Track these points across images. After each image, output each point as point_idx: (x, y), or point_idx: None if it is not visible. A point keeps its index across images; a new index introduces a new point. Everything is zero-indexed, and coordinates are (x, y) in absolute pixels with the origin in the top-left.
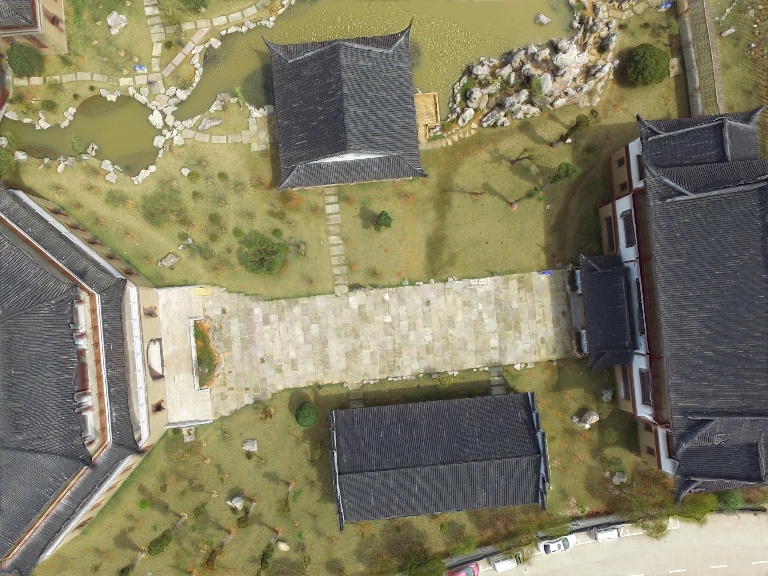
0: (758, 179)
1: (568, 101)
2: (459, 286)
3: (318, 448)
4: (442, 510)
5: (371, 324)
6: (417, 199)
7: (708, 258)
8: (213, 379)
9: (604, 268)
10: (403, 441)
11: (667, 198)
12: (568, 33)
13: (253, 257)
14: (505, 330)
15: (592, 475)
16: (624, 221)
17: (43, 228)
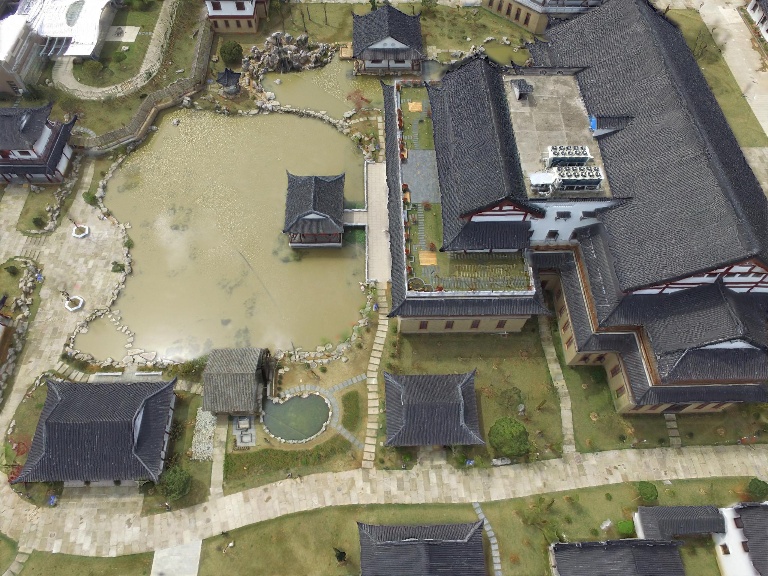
0: None
1: None
2: (340, 1)
3: None
4: None
5: None
6: None
7: None
8: None
9: None
10: None
11: None
12: (266, 77)
13: None
14: None
15: None
16: None
17: None
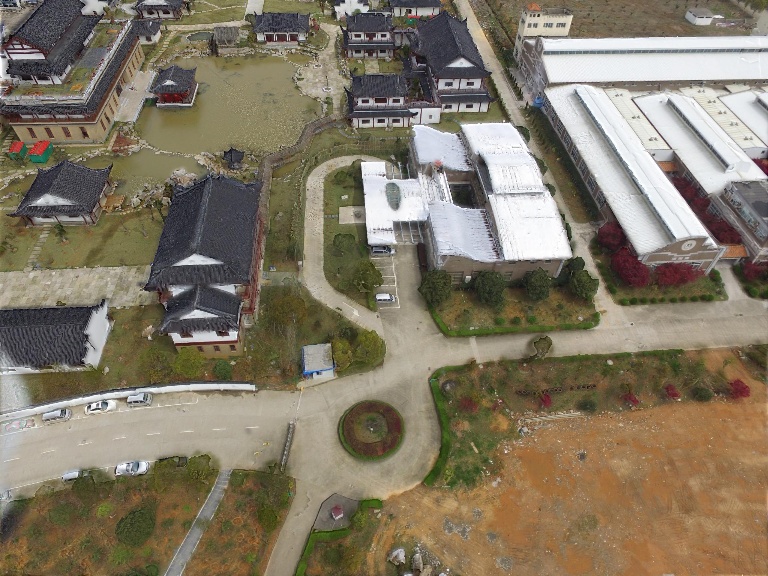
0: None
1: None
2: (100, 270)
3: None
4: (15, 366)
5: (36, 285)
6: (95, 234)
7: None
8: None
9: None
10: (7, 320)
11: None
12: None
13: None
14: (119, 290)
15: (143, 366)
16: None
17: None
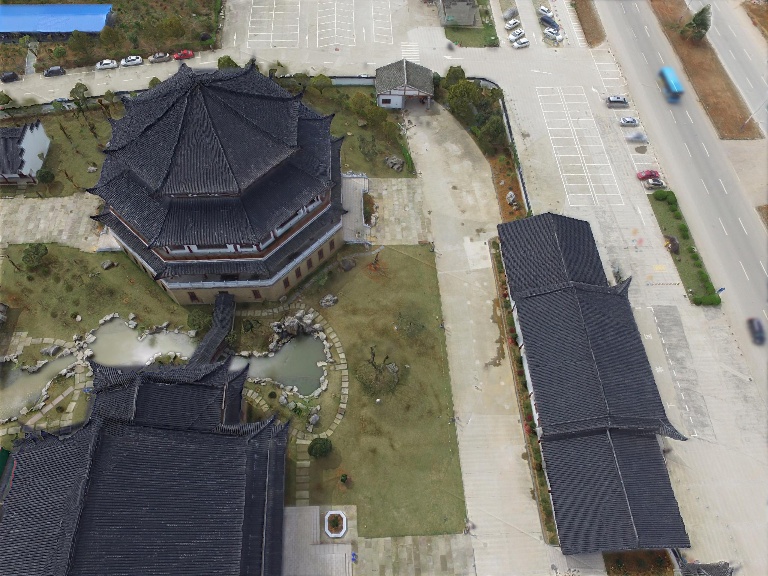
0: None
1: None
2: None
3: (39, 156)
4: None
5: None
6: None
7: None
8: None
9: None
10: None
11: None
12: None
13: None
14: None
15: None
16: None
17: (136, 248)
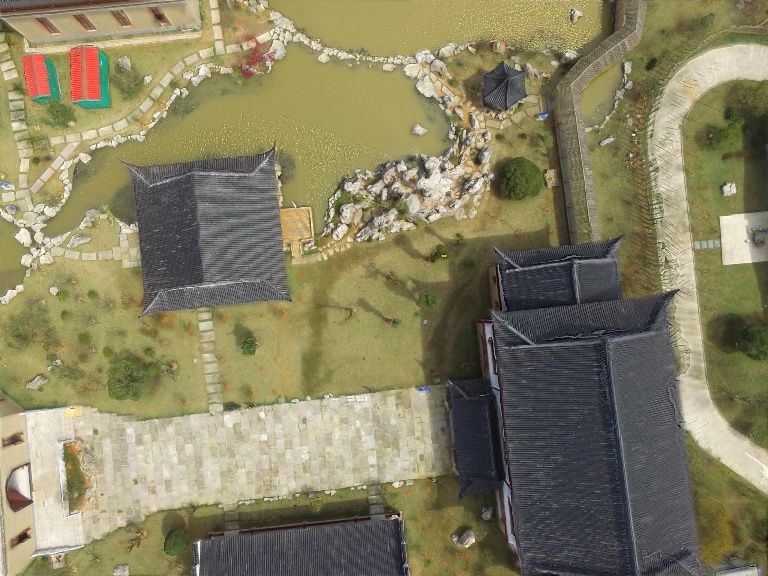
0: (594, 334)
1: (443, 215)
2: (336, 403)
3: None
4: None
5: (246, 443)
6: (292, 315)
7: (551, 408)
8: (84, 503)
9: (470, 395)
10: (268, 574)
11: (512, 345)
12: (445, 143)
13: (117, 384)
14: (383, 447)
15: None
16: (491, 346)
17: None
